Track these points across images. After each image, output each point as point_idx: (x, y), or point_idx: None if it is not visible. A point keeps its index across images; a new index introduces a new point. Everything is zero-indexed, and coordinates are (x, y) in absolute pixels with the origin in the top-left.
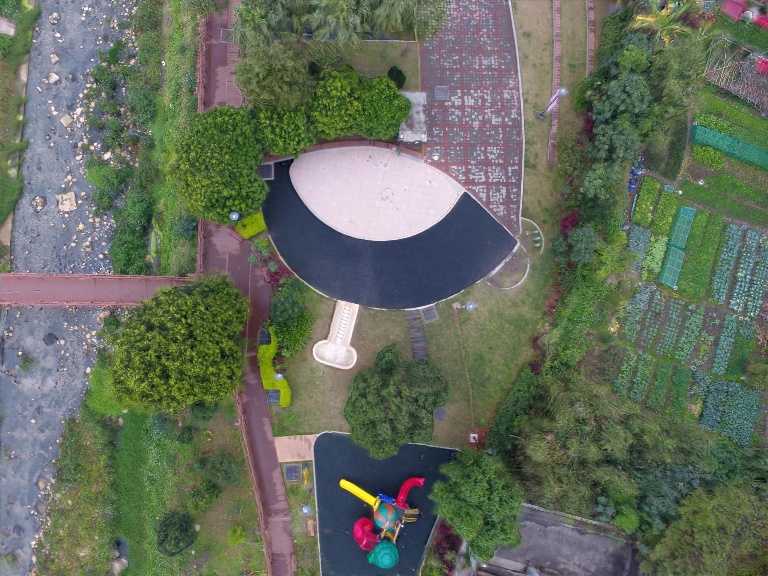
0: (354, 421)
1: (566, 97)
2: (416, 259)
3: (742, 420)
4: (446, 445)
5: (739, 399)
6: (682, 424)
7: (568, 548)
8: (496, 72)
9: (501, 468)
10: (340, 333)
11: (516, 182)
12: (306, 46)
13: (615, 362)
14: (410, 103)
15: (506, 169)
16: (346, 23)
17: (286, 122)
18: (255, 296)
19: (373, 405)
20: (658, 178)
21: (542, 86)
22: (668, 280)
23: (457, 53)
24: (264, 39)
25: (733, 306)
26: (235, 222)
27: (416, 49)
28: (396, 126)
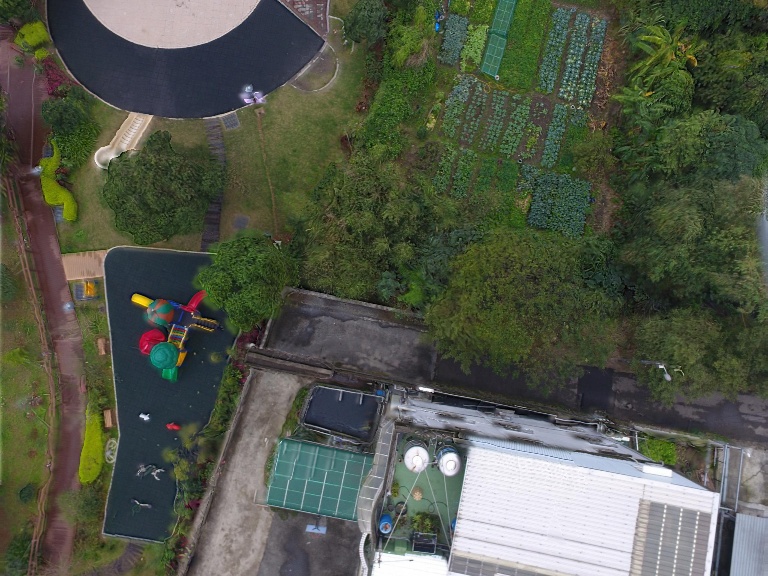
0: (108, 199)
1: None
2: (214, 65)
3: (574, 213)
4: None
5: (570, 191)
6: (509, 221)
7: (368, 342)
8: None
9: None
10: (126, 139)
11: None
12: None
13: (432, 159)
14: None
15: None
16: None
17: None
18: (39, 110)
19: (123, 177)
20: None
21: None
22: (488, 69)
23: None
24: None
25: (563, 94)
26: None
27: None
28: None
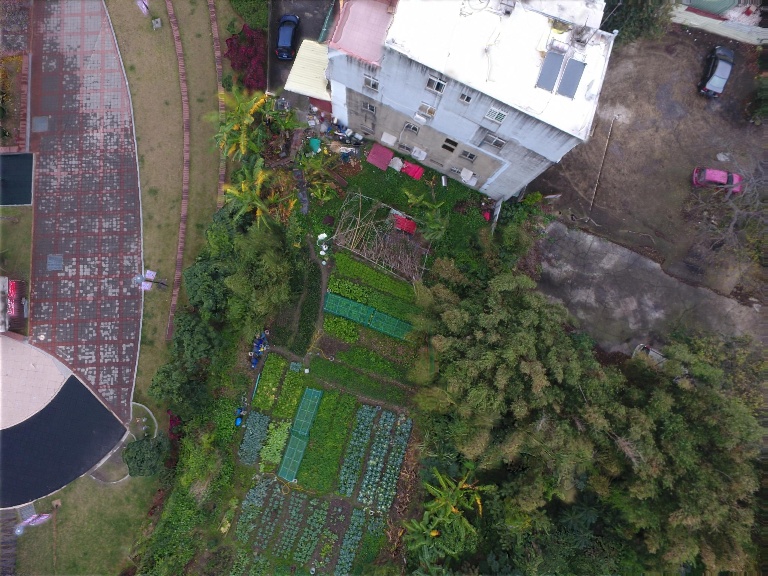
0: None
1: (190, 263)
2: (14, 452)
3: None
4: None
5: None
6: None
7: None
8: (117, 236)
9: None
10: None
11: (130, 361)
12: None
13: (225, 566)
14: None
15: (120, 347)
16: None
17: None
18: None
19: None
20: (285, 354)
21: (166, 250)
22: (286, 473)
23: (75, 216)
24: None
25: (362, 498)
26: None
27: (30, 213)
28: None
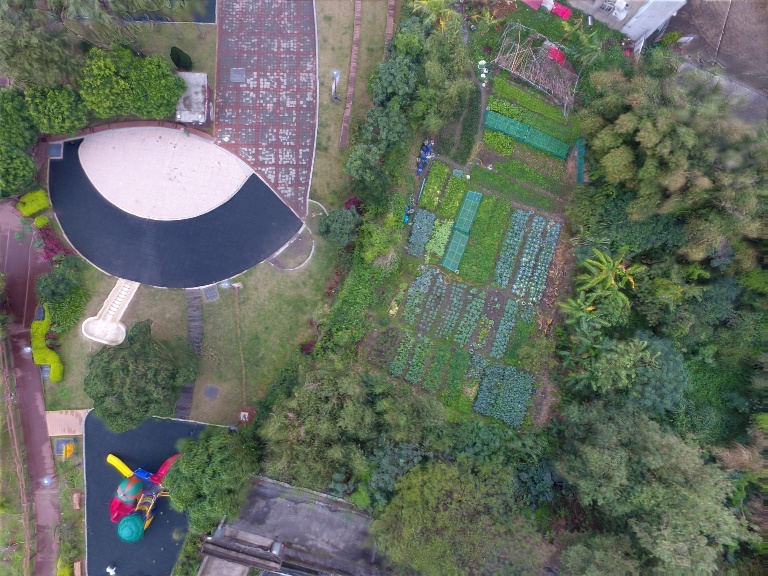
0: (88, 394)
1: (362, 81)
2: (200, 239)
3: (516, 404)
4: (217, 422)
5: (515, 383)
6: (457, 407)
7: (317, 525)
8: (294, 55)
9: (249, 444)
10: (113, 310)
11: (306, 164)
12: (103, 27)
13: (392, 344)
14: (185, 83)
15: (297, 151)
16: (85, 0)
17: (49, 99)
18: (35, 272)
19: (102, 378)
20: (448, 162)
21: (339, 70)
22: (449, 264)
23: (256, 36)
24: (3, 15)
25: (516, 291)
26: (0, 198)
27: (215, 31)
28: (170, 106)
